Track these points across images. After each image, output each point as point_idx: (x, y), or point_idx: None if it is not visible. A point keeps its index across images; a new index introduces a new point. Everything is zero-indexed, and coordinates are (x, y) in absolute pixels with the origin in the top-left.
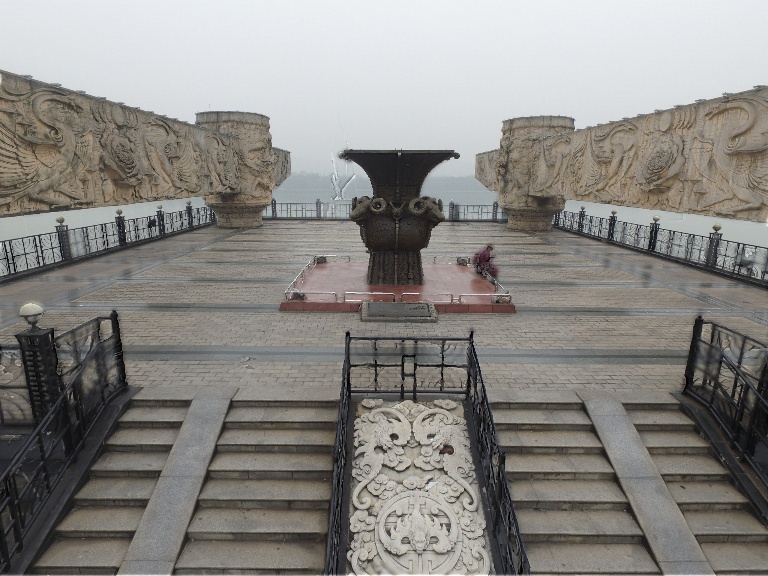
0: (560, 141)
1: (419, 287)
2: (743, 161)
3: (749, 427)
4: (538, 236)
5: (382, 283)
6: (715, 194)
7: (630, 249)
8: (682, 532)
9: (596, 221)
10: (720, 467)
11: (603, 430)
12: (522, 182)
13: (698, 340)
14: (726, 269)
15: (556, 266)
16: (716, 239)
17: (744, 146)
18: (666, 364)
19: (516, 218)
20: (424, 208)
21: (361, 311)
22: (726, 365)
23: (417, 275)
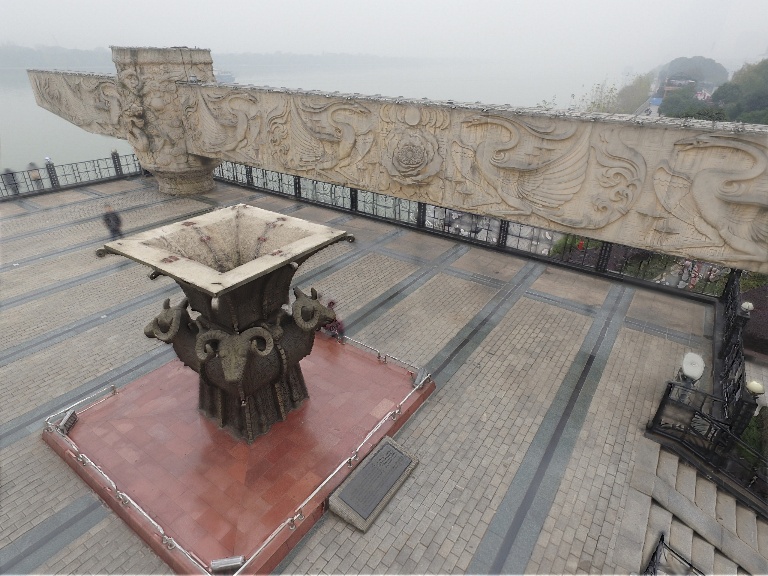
0: (237, 97)
1: (314, 406)
2: (511, 174)
3: (721, 453)
4: (221, 204)
5: (268, 429)
6: (481, 196)
7: (330, 209)
8: (761, 560)
9: (273, 175)
10: (711, 484)
11: (682, 515)
12: (175, 138)
13: (669, 399)
14: (437, 229)
15: (329, 269)
16: (424, 204)
17: (509, 161)
18: (592, 397)
19: (175, 181)
20: (317, 316)
21: (334, 513)
22: (701, 417)
23: (300, 390)
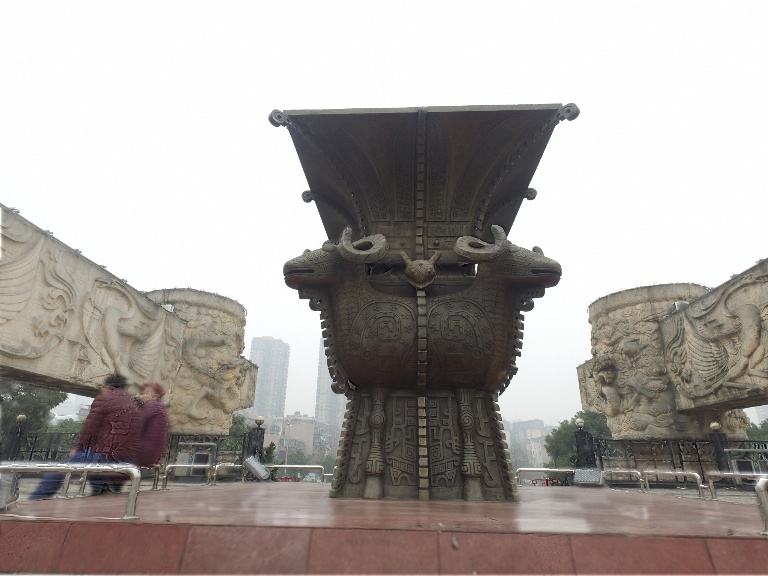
0: None
1: None
2: None
3: None
4: None
5: None
6: None
7: None
8: None
9: None
10: None
11: None
12: None
13: None
14: None
15: None
16: None
17: None
18: None
19: None
20: None
21: None
22: None
23: None
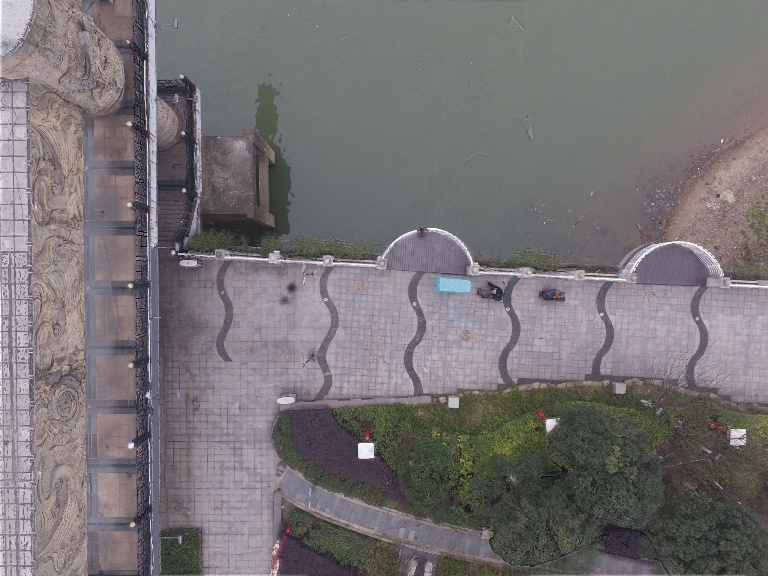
0: None
1: None
2: None
3: None
4: (86, 162)
5: None
6: None
7: None
8: None
9: None
10: None
11: None
12: None
13: None
14: None
15: None
16: None
17: None
18: None
19: None
20: None
21: None
22: None
23: None
